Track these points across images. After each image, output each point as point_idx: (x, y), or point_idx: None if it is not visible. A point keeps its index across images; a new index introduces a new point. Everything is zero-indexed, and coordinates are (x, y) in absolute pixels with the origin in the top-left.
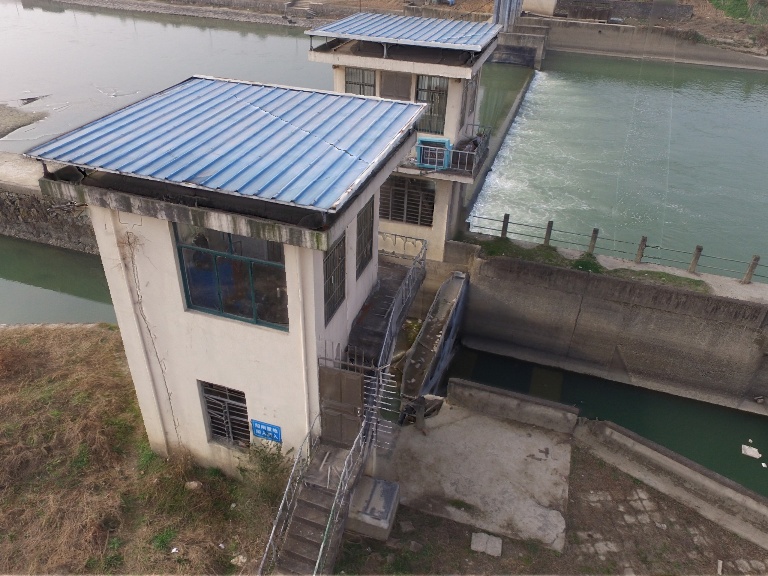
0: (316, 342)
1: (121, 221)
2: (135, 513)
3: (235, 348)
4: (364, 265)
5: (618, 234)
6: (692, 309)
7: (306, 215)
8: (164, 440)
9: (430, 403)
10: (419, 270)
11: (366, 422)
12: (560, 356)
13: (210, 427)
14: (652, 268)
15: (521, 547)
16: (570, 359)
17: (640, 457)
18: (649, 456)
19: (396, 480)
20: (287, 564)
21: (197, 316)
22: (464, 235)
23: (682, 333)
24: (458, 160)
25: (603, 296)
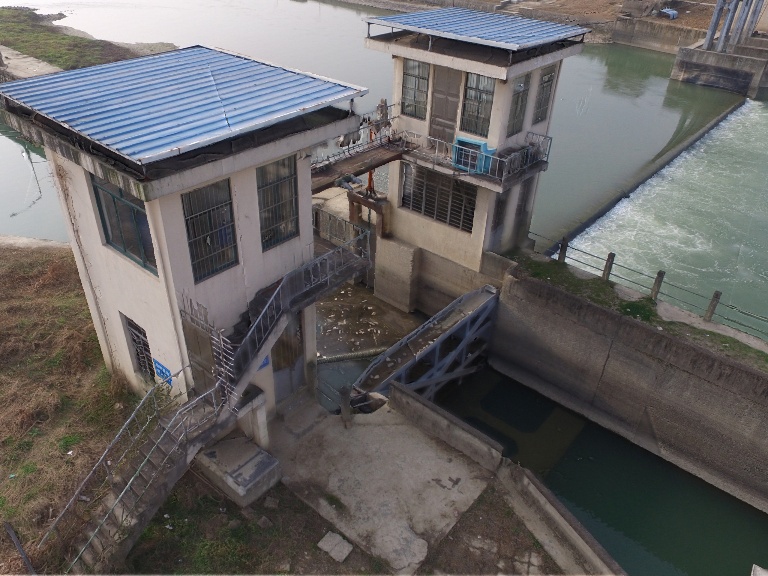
0: (175, 293)
1: (58, 155)
2: (65, 414)
3: (133, 287)
4: (282, 239)
5: (738, 291)
6: (737, 385)
7: (155, 168)
8: (110, 361)
9: (374, 401)
10: (362, 260)
11: (220, 383)
12: (585, 402)
13: (137, 359)
14: (721, 330)
15: (367, 562)
16: (595, 408)
17: (549, 519)
18: (557, 521)
19: (291, 459)
20: (119, 489)
21: (109, 251)
22: (519, 251)
23: (723, 411)
24: (489, 165)
25: (635, 345)
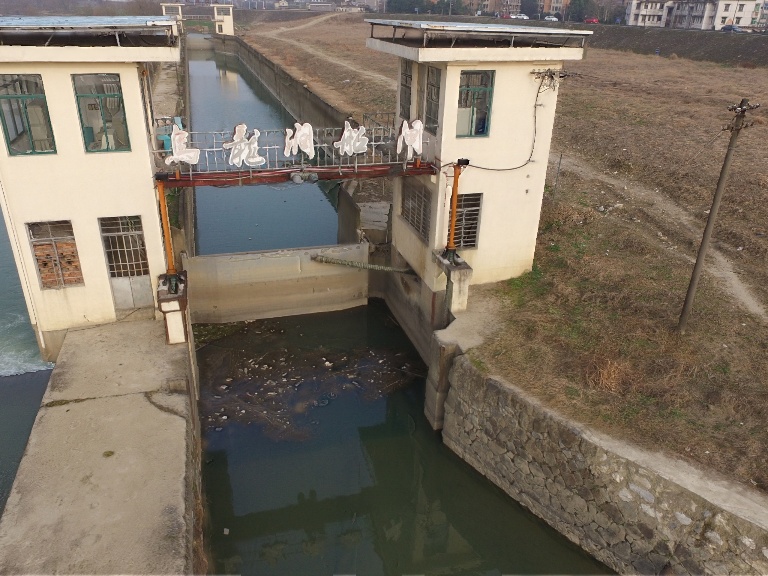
0: None
1: None
2: None
3: None
4: None
5: None
6: None
7: None
8: None
9: None
10: None
11: None
12: None
13: None
14: None
15: None
16: None
17: None
18: None
19: None
20: None
21: None
22: None
23: None
24: None
25: None
